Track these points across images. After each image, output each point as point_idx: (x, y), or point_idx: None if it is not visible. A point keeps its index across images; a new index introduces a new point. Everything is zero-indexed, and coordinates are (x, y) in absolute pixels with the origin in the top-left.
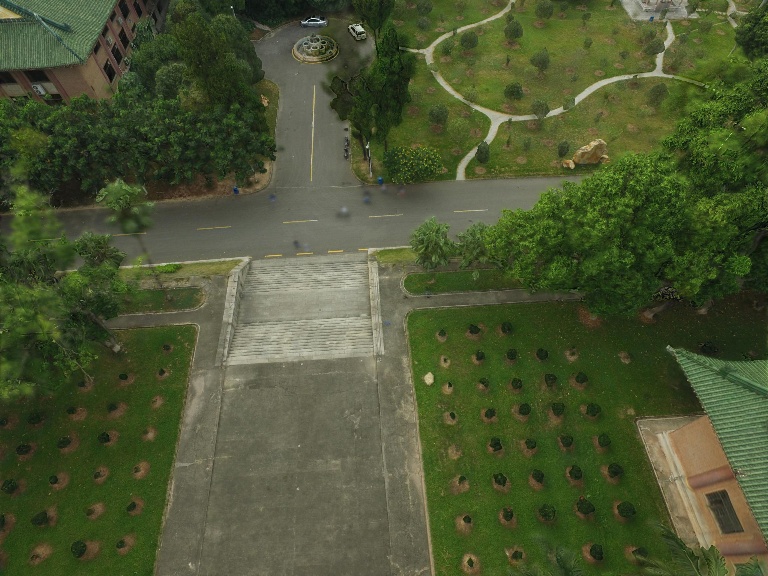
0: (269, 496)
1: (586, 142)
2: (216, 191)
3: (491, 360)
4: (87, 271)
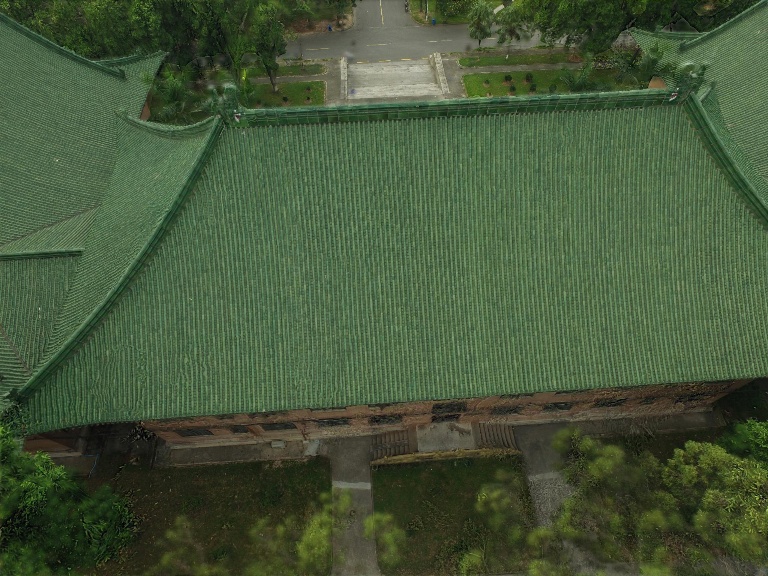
0: None
1: None
2: (315, 30)
3: (519, 95)
4: None
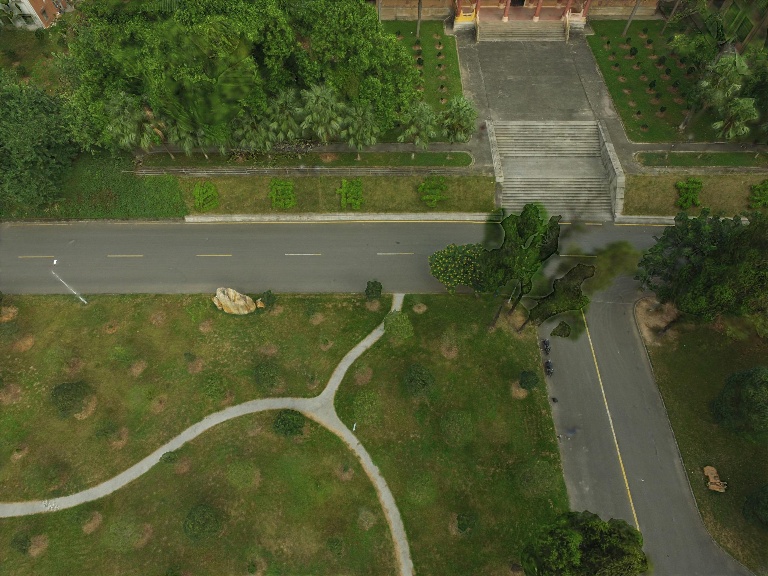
0: (544, 69)
1: (218, 345)
2: None
3: None
4: (762, 202)
